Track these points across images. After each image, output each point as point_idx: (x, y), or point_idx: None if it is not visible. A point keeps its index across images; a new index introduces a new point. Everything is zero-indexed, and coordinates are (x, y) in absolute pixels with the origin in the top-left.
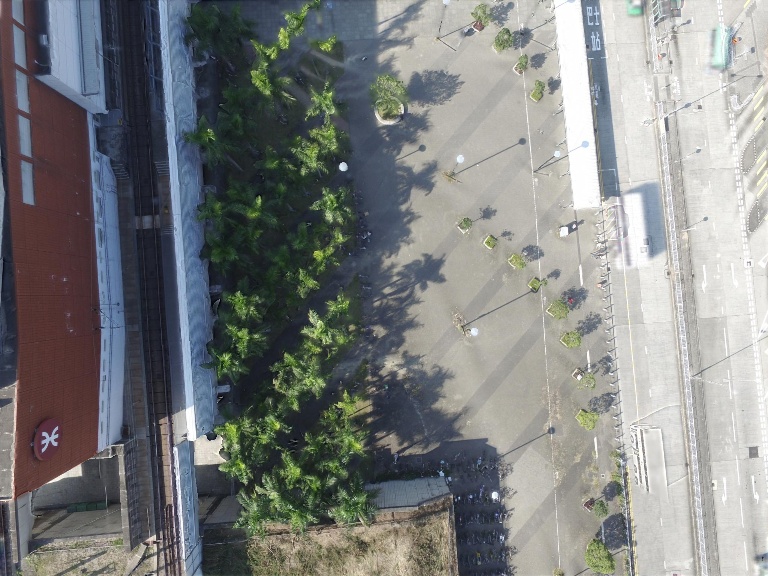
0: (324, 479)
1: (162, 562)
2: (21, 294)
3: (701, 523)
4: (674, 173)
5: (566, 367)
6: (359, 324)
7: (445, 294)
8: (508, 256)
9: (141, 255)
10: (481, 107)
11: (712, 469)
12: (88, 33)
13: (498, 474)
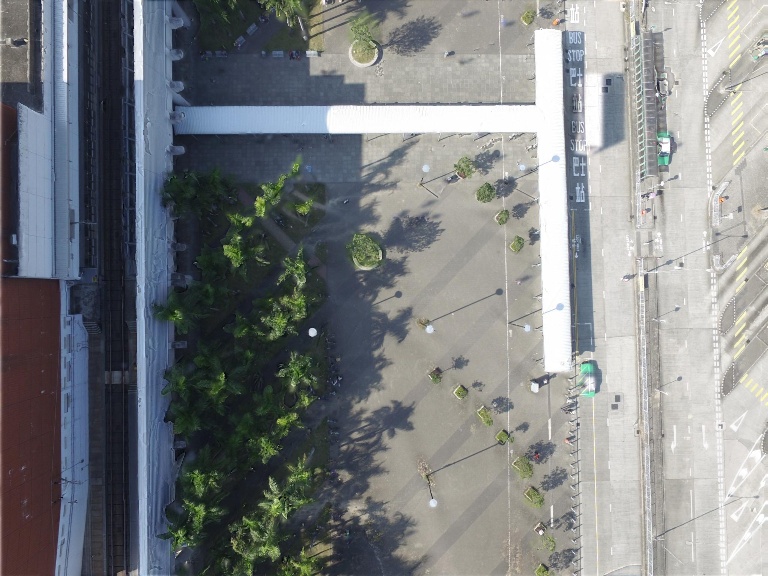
0: None
1: None
2: None
3: None
4: (651, 331)
5: (529, 521)
6: (325, 467)
7: (412, 442)
8: (477, 407)
9: (108, 409)
10: (460, 255)
11: None
12: (61, 216)
13: None
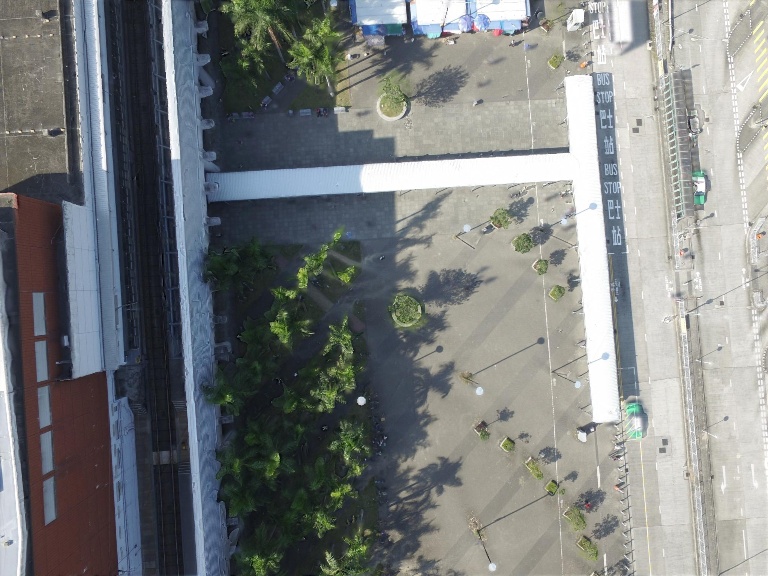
0: None
1: None
2: None
3: None
4: (695, 372)
5: (582, 571)
6: (374, 529)
7: (461, 498)
8: (525, 458)
9: (158, 490)
10: (499, 306)
11: None
12: (108, 308)
13: None
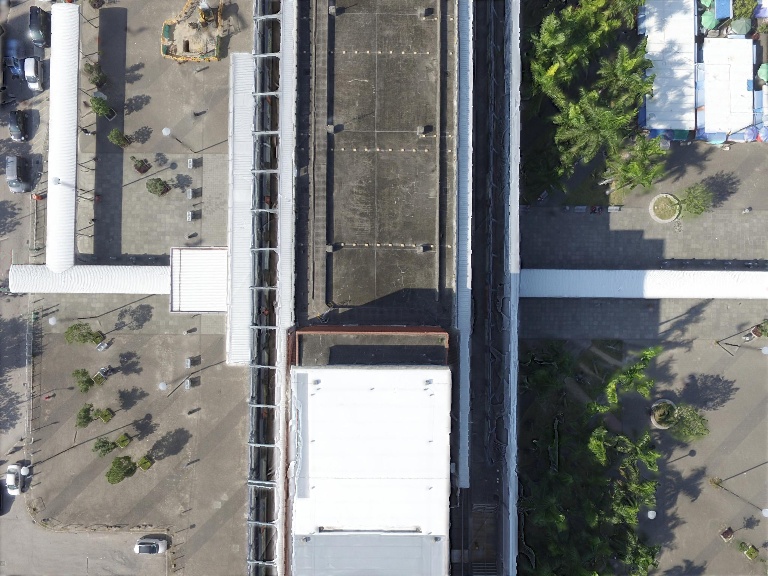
0: None
1: None
2: None
3: None
4: None
5: None
6: None
7: None
8: (767, 567)
9: None
10: (753, 415)
11: None
12: (464, 425)
13: None
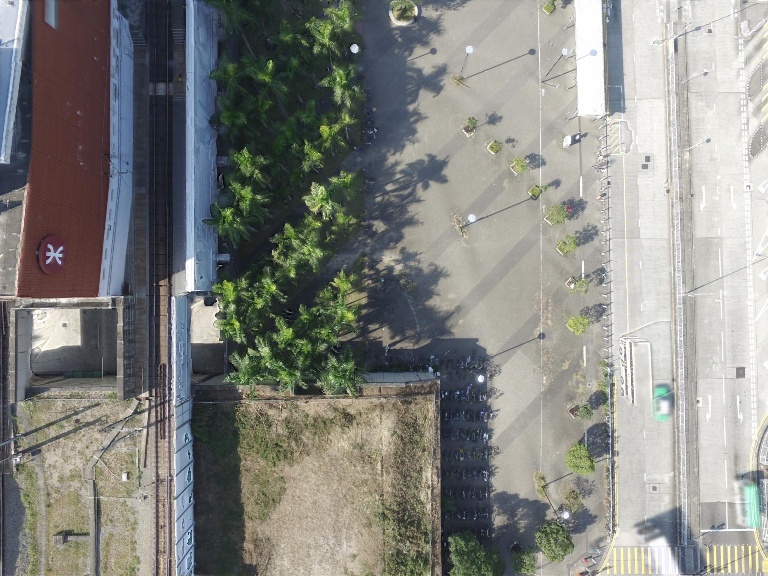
0: (315, 343)
1: (153, 419)
2: (37, 104)
3: (683, 437)
4: (680, 93)
5: (560, 275)
6: (360, 218)
7: (446, 195)
8: (510, 162)
9: (152, 121)
10: (494, 15)
11: (698, 386)
12: None
13: (486, 373)
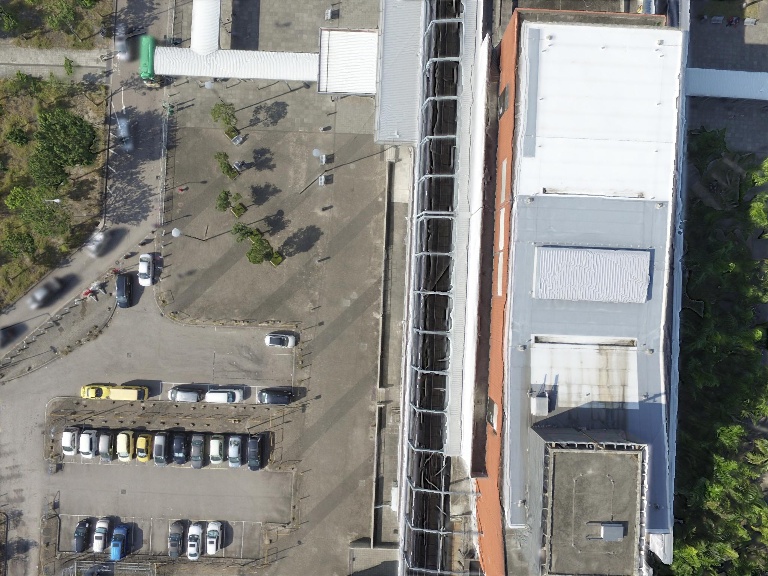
0: None
1: None
2: None
3: None
4: None
5: None
6: (742, 437)
7: None
8: None
9: None
10: None
11: None
12: None
13: None
